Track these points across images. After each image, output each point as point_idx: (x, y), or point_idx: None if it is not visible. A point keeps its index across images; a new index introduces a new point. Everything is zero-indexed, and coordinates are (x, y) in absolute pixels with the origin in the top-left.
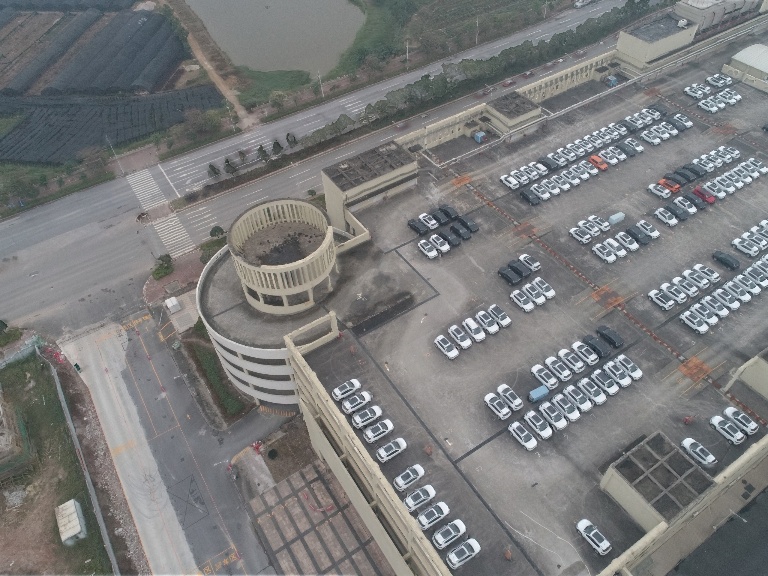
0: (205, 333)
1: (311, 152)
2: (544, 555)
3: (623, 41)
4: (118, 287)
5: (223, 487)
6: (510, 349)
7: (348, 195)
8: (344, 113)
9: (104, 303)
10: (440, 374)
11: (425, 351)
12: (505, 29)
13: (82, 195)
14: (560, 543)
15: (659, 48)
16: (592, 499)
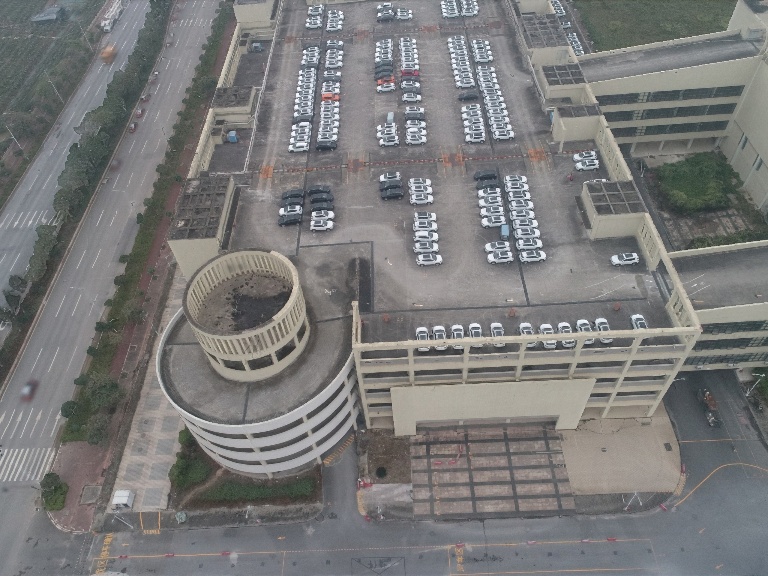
0: (192, 480)
1: (45, 282)
2: (623, 291)
3: (240, 13)
4: (26, 560)
5: (384, 533)
6: (456, 228)
7: (219, 238)
8: (21, 232)
9: None
10: (449, 277)
11: (421, 275)
12: (72, 78)
13: None
14: (619, 279)
15: (269, 5)
16: (597, 248)
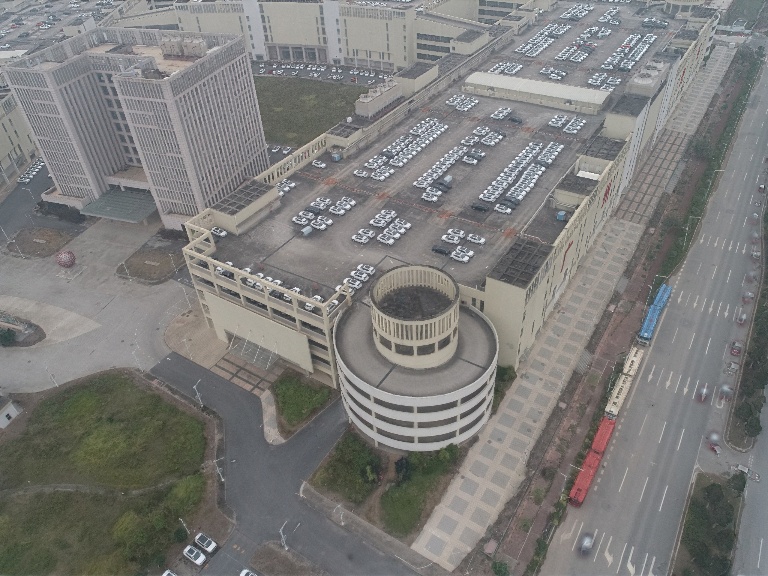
0: None
1: None
2: None
3: None
4: (765, 48)
5: None
6: None
7: None
8: None
9: None
10: None
11: None
12: None
13: None
14: None
15: None
16: None
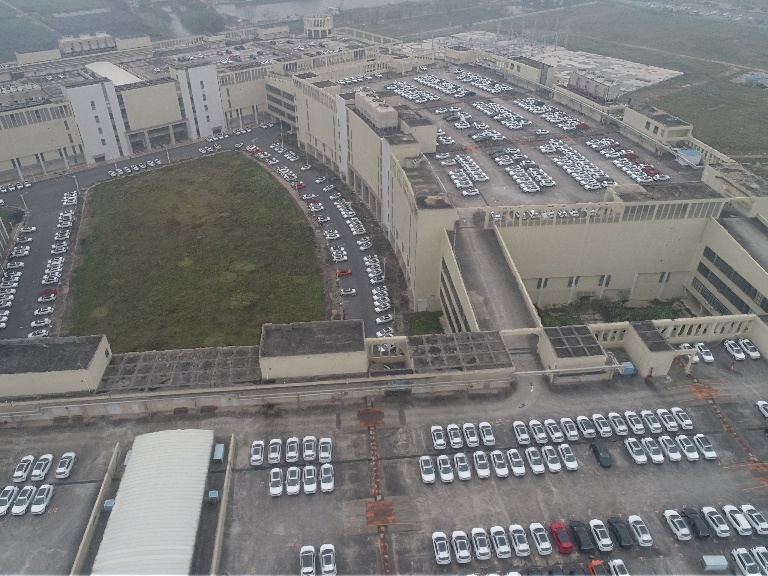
0: None
1: None
2: None
3: None
4: None
5: None
6: None
7: None
8: None
9: None
10: None
11: None
12: None
13: None
14: None
15: None
16: None
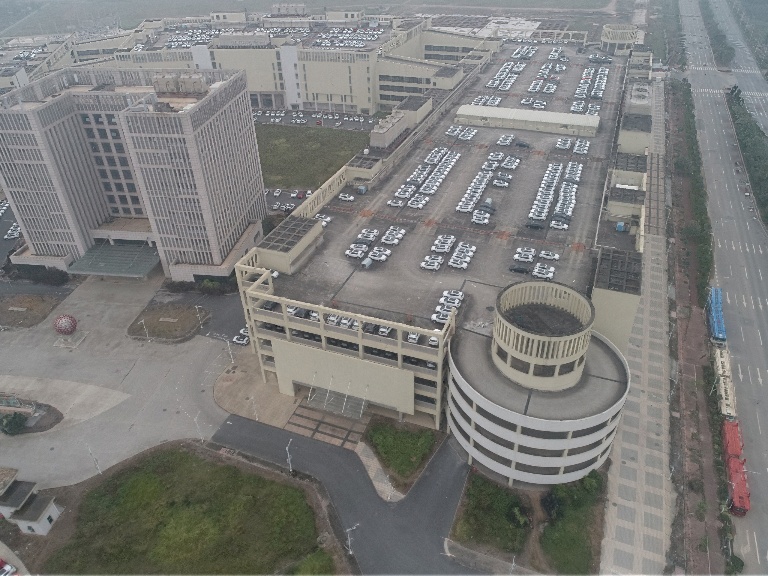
0: None
1: None
2: None
3: None
4: None
5: None
6: None
7: None
8: None
9: (679, 78)
10: None
11: None
12: None
13: (767, 87)
14: None
15: None
16: None
